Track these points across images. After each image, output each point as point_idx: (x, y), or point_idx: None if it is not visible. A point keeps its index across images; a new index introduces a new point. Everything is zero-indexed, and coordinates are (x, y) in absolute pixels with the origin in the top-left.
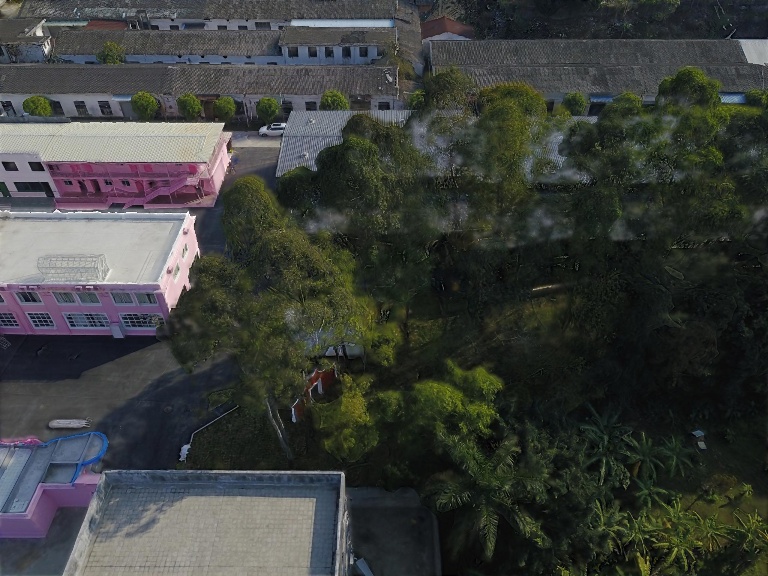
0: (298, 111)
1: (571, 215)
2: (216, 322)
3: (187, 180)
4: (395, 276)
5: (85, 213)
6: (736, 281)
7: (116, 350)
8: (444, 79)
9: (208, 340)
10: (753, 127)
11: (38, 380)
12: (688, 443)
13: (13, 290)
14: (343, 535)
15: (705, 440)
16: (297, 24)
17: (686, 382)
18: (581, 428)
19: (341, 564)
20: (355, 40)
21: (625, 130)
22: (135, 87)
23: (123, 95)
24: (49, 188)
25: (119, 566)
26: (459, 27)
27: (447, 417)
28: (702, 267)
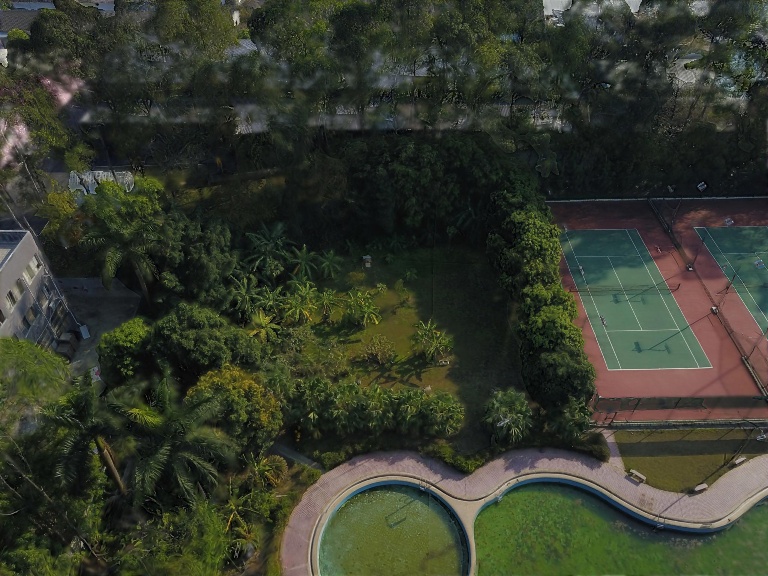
0: None
1: (231, 76)
2: None
3: None
4: (103, 118)
5: None
6: (384, 137)
7: None
8: None
9: None
10: (351, 10)
11: None
12: (358, 263)
13: None
14: (33, 277)
15: (371, 262)
16: None
17: (344, 211)
18: (246, 234)
19: (5, 274)
20: None
21: (265, 13)
22: (13, 26)
23: (2, 32)
24: None
25: None
26: None
27: (115, 204)
28: (368, 131)
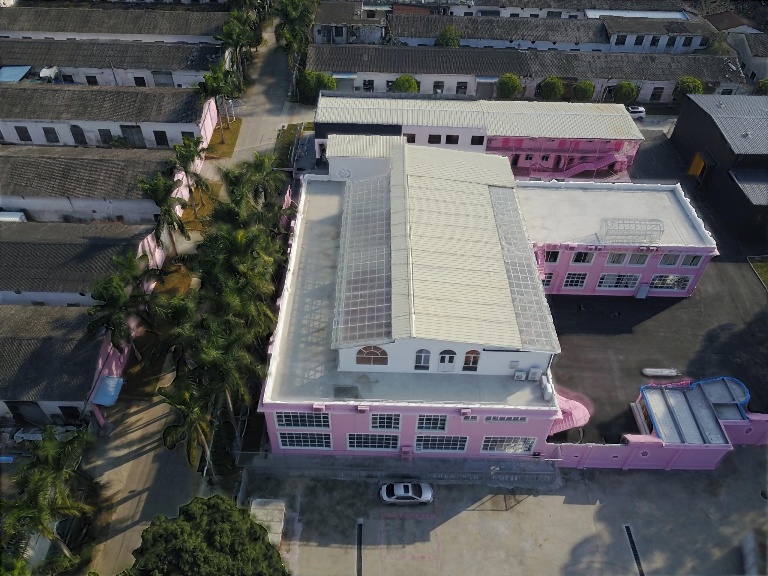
0: (694, 94)
1: None
2: None
3: (616, 156)
4: None
5: (580, 183)
6: None
7: (645, 309)
8: None
9: None
10: None
11: (597, 334)
12: None
13: (578, 250)
14: None
15: None
16: (593, 14)
17: None
18: None
19: None
20: (680, 30)
21: None
22: (496, 69)
23: (486, 77)
24: None
25: None
26: (747, 21)
27: None
28: None
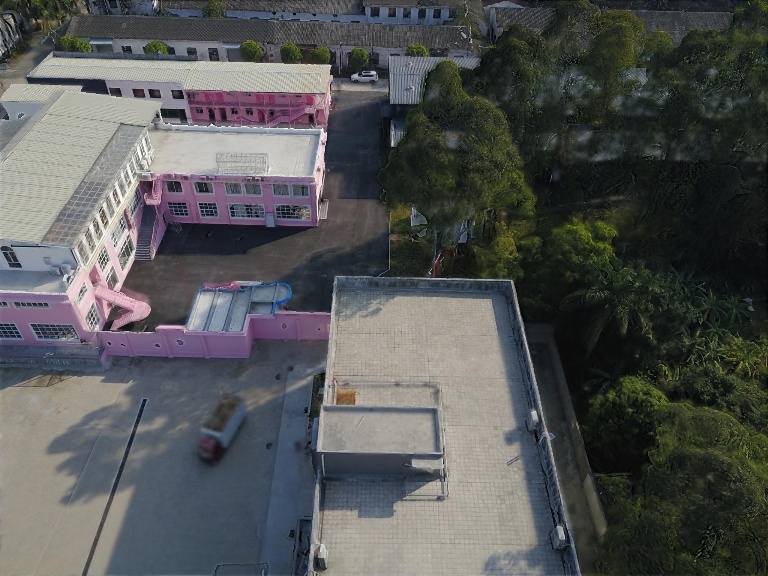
0: (395, 56)
1: (665, 111)
2: (439, 156)
3: (306, 110)
4: (532, 154)
5: (236, 127)
6: None
7: (270, 236)
8: (577, 1)
9: (423, 176)
10: None
11: (212, 255)
12: None
13: (194, 180)
14: None
15: (753, 305)
16: None
17: (742, 254)
18: None
19: None
20: (430, 3)
21: (709, 46)
22: (242, 36)
23: (232, 43)
24: (184, 115)
25: (361, 333)
26: None
27: (581, 250)
28: (754, 168)
